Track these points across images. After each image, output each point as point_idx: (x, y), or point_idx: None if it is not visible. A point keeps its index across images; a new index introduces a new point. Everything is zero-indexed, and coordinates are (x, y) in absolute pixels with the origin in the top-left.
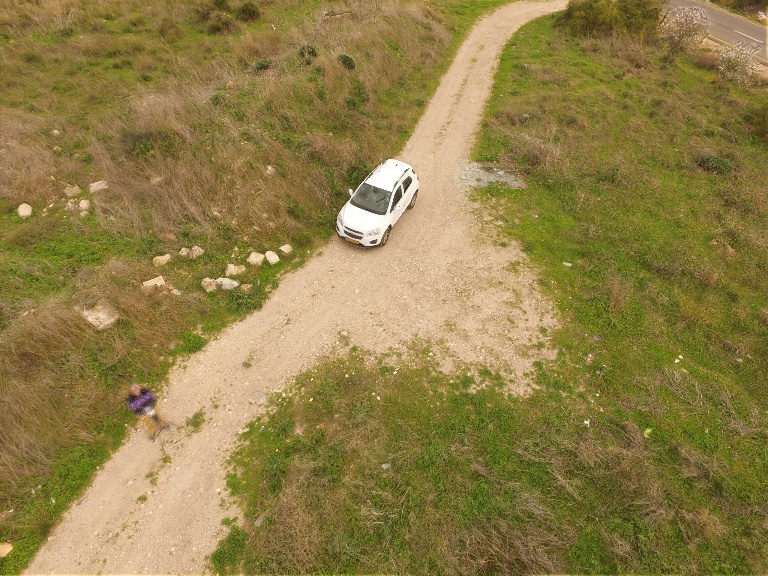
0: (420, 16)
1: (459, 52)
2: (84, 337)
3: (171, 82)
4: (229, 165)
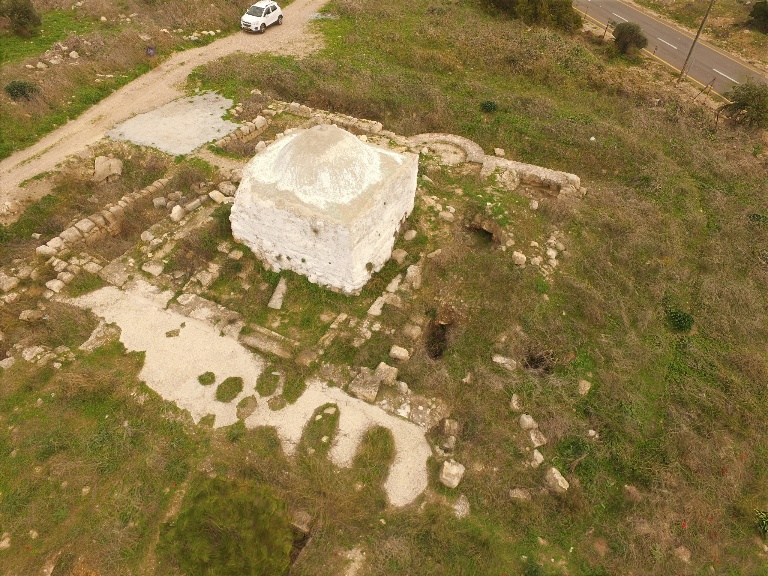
0: None
1: None
2: (140, 42)
3: None
4: (193, 1)
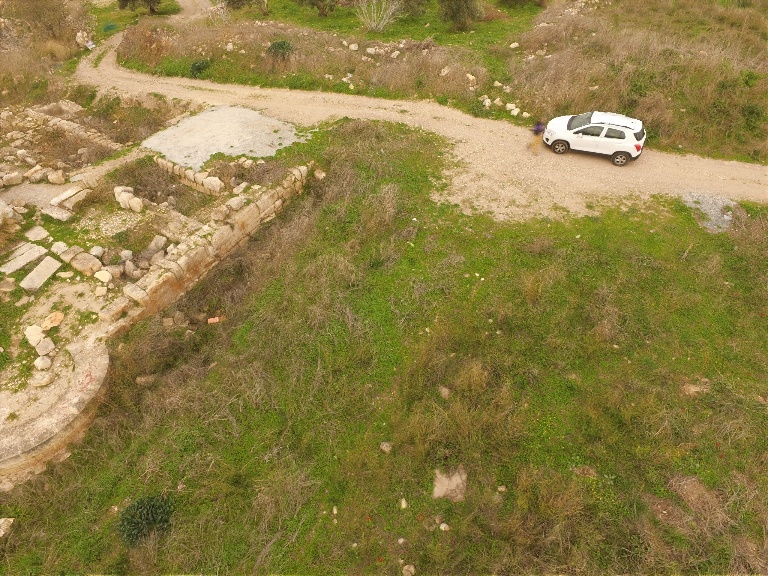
0: None
1: None
2: None
3: (700, 46)
4: None
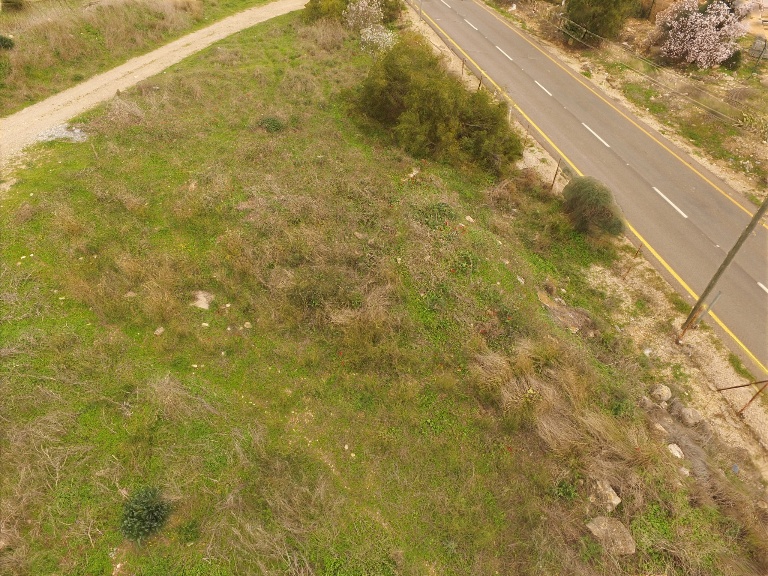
0: (162, 7)
1: (182, 38)
2: None
3: None
4: None
